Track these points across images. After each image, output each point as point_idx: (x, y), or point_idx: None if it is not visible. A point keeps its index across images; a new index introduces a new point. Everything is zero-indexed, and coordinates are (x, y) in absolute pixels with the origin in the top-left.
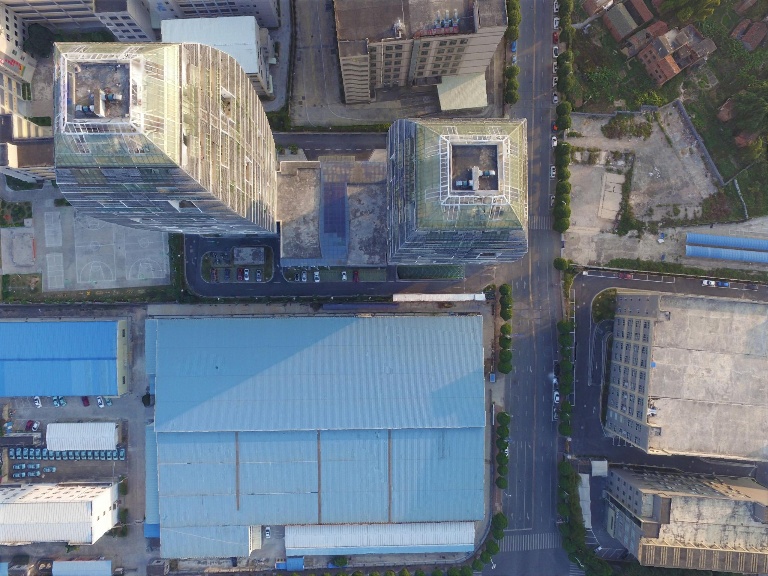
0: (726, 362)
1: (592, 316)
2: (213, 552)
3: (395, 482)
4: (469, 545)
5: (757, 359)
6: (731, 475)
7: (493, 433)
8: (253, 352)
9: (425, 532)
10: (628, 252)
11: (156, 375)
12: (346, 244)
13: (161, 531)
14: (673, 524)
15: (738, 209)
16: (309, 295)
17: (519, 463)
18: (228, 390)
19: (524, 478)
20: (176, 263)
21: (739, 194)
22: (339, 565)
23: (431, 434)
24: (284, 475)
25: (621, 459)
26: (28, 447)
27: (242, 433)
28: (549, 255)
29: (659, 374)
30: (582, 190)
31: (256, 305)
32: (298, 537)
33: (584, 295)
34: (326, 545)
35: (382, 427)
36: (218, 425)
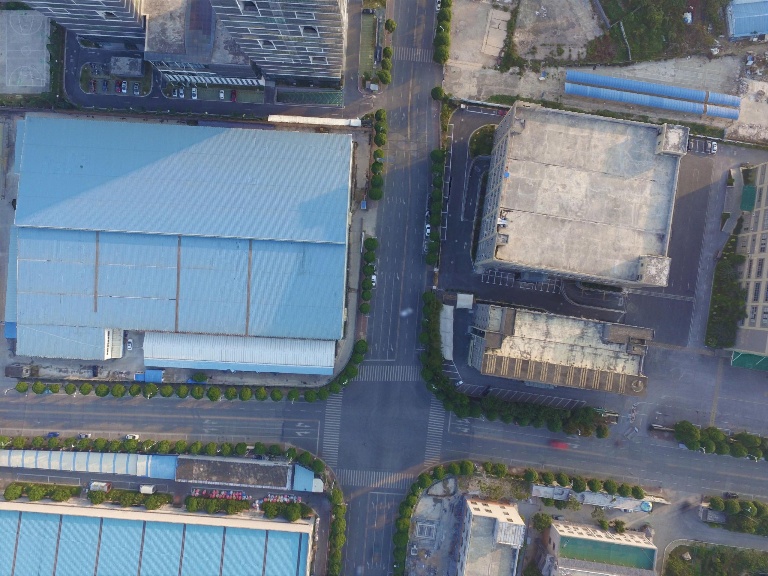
0: (582, 179)
1: (469, 152)
2: (69, 352)
3: (254, 294)
4: (328, 368)
5: (614, 178)
6: (599, 319)
7: (361, 261)
8: (119, 154)
9: (284, 351)
10: (508, 89)
11: (20, 170)
12: (211, 42)
13: (18, 327)
14: (520, 340)
15: (622, 52)
16: (186, 112)
17: (386, 294)
18: (91, 189)
19: (390, 309)
20: (53, 68)
21: (624, 37)
22: (197, 379)
23: (292, 248)
24: (143, 279)
25: (489, 296)
26: None
27: (103, 234)
28: (430, 88)
29: (513, 186)
30: (467, 25)
31: (133, 119)
32: (156, 347)
33: (462, 130)
34: (185, 358)
35: (242, 235)
36: (78, 222)
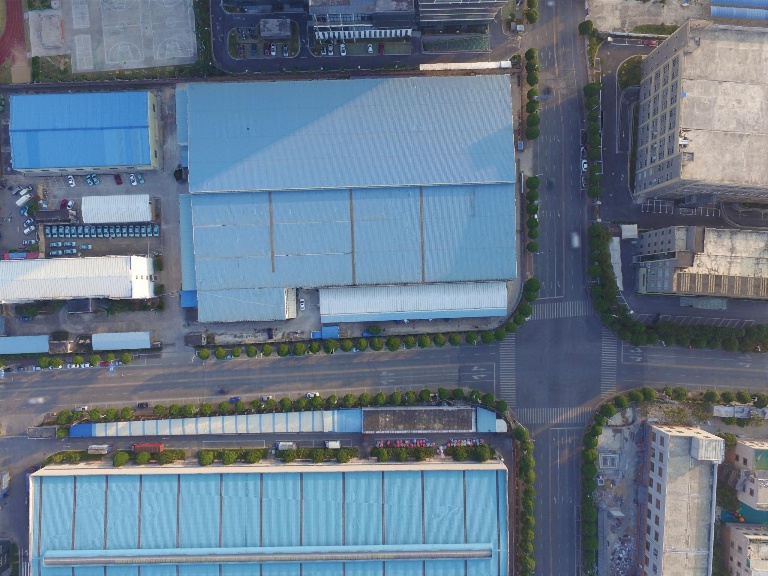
0: (756, 93)
1: (618, 84)
2: (250, 315)
3: (428, 241)
4: (502, 309)
5: None
6: None
7: (522, 201)
8: (283, 114)
9: (458, 295)
10: (652, 18)
11: (189, 137)
12: None
13: (198, 294)
14: (707, 258)
15: None
16: (336, 69)
17: (549, 232)
18: (260, 150)
19: (554, 247)
20: (203, 36)
21: None
22: (374, 332)
23: (462, 191)
24: (318, 236)
25: (650, 225)
26: (64, 225)
27: (275, 193)
28: (573, 25)
29: (690, 106)
30: None
31: None
32: (333, 303)
33: (609, 63)
34: (361, 311)
35: (414, 183)
36: (251, 184)
